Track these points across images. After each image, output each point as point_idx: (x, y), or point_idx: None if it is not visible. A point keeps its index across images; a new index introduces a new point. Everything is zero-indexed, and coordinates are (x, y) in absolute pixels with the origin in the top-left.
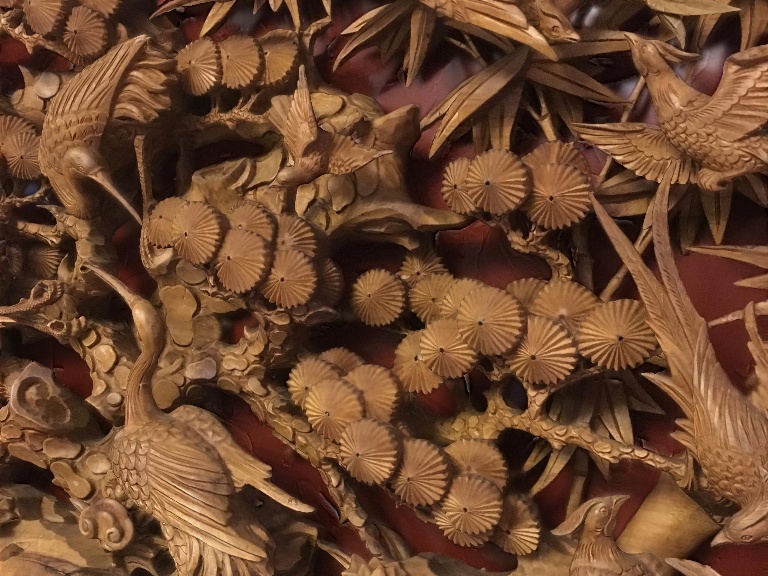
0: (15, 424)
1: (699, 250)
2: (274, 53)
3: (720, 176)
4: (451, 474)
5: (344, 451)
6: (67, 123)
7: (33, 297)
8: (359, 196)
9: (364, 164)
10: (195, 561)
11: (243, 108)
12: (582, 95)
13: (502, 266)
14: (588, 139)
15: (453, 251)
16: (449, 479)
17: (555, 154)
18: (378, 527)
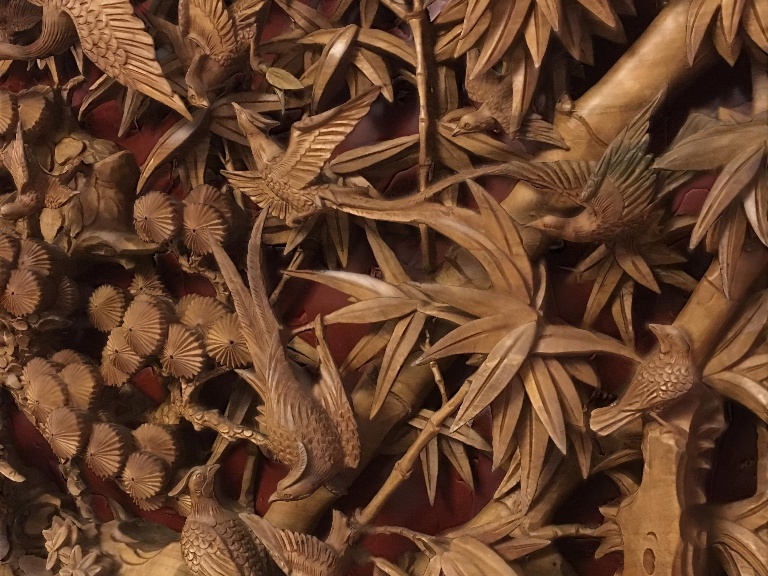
0: None
1: (289, 273)
2: (26, 106)
3: (295, 216)
4: (128, 451)
5: (47, 432)
6: None
7: None
8: None
9: (65, 201)
10: None
11: (4, 151)
12: (249, 145)
13: (190, 283)
14: (232, 183)
15: (171, 270)
16: (125, 455)
17: (203, 195)
18: (106, 498)
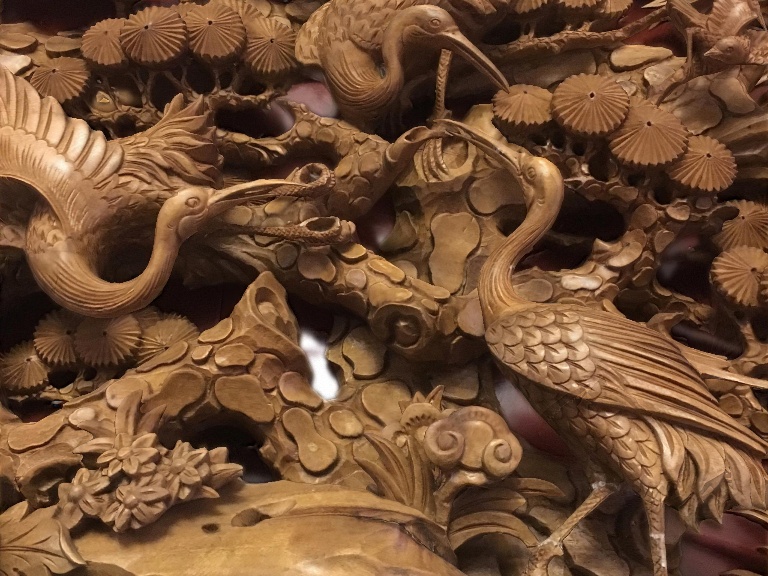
0: (246, 342)
1: None
2: None
3: None
4: None
5: None
6: None
7: (300, 179)
8: (731, 117)
9: None
10: (681, 453)
11: (580, 29)
12: None
13: None
14: None
15: None
16: None
17: None
18: None
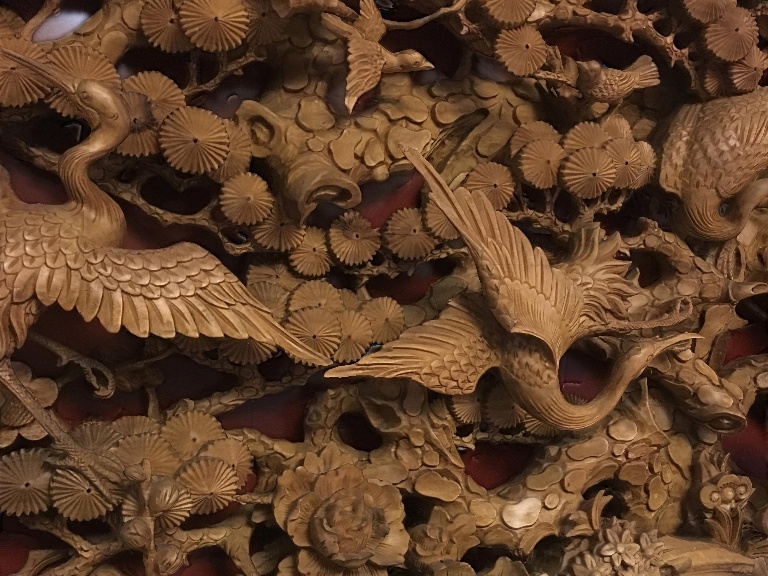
0: (647, 442)
1: None
2: None
3: None
4: None
5: None
6: (755, 153)
7: None
8: None
9: None
10: None
11: None
12: None
13: None
14: None
15: None
16: None
17: None
18: None
